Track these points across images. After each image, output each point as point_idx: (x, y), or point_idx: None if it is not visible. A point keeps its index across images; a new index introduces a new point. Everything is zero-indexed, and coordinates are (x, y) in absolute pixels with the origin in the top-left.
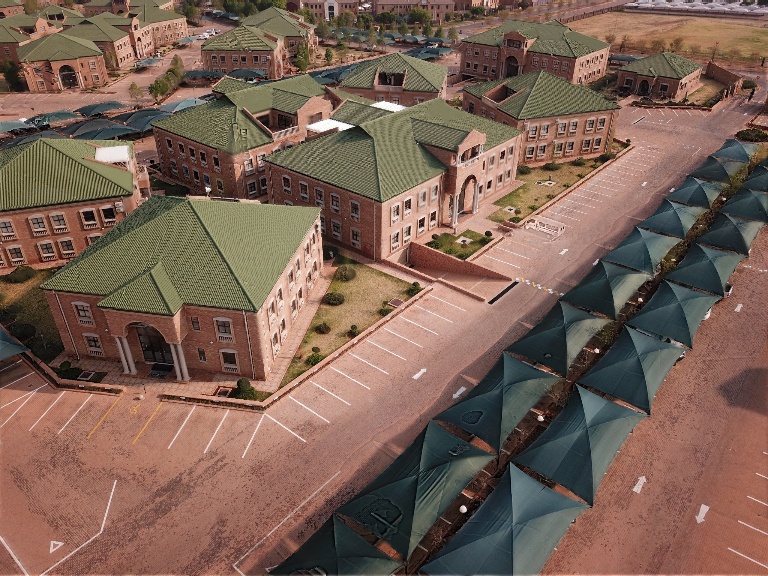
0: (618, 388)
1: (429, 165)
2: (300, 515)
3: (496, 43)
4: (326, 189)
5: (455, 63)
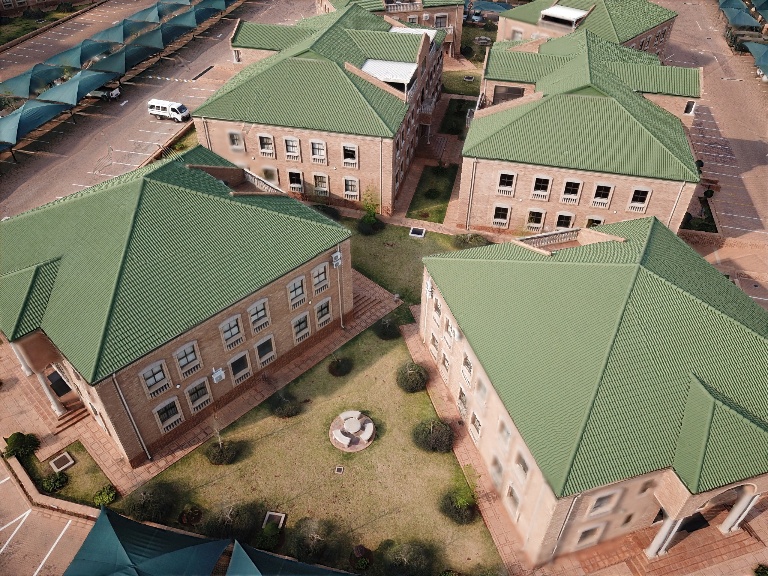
0: None
1: None
2: (266, 8)
3: None
4: None
5: None
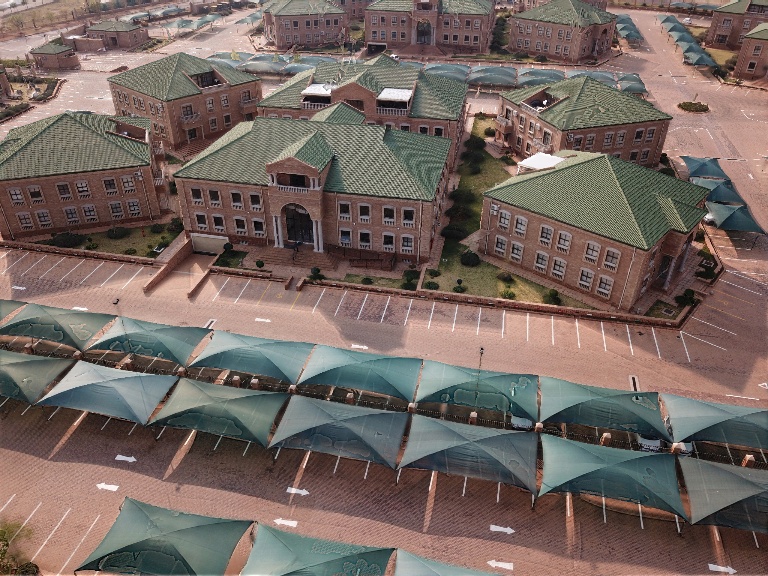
0: None
1: None
2: None
3: None
4: None
5: None
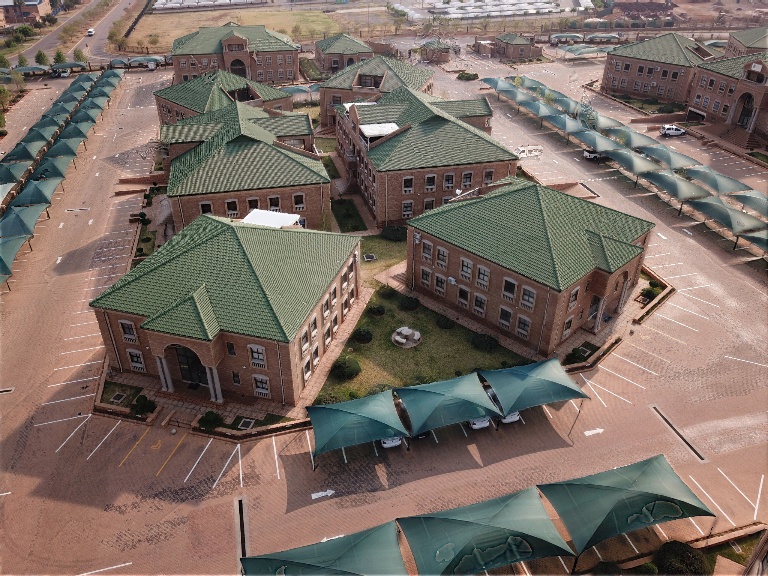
0: (732, 188)
1: (481, 131)
2: None
3: (212, 51)
4: (457, 171)
5: (135, 83)
